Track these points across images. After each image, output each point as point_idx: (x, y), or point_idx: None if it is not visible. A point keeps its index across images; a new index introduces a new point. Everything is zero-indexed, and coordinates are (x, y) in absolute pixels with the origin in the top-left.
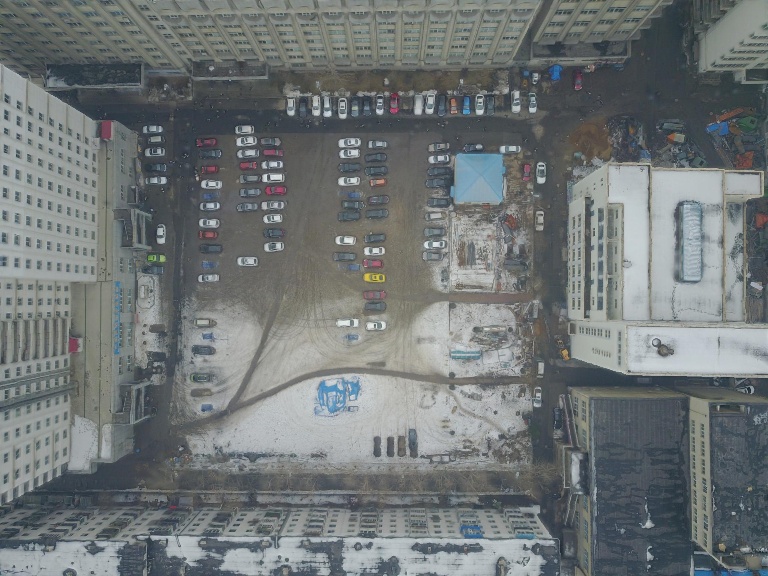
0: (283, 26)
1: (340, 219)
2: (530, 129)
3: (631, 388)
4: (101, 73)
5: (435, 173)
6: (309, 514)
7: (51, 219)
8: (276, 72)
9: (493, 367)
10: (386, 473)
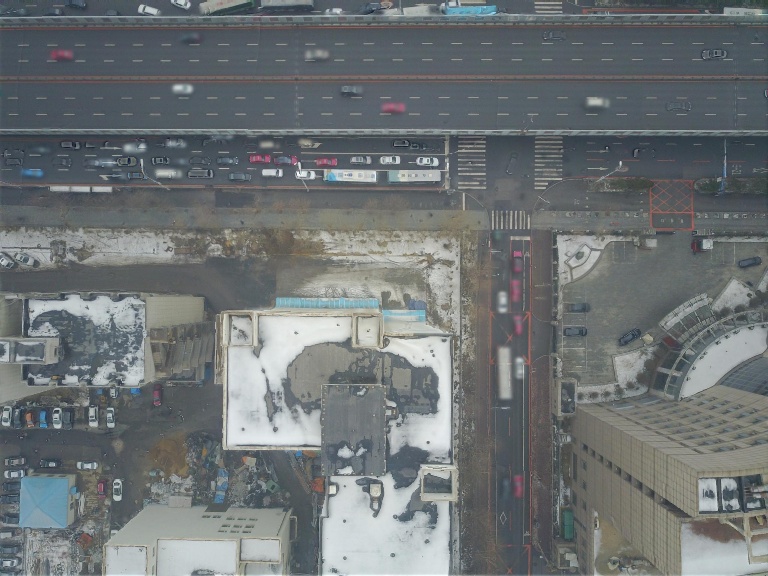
0: None
1: None
2: (110, 443)
3: None
4: None
5: (8, 489)
6: None
7: None
8: None
9: None
10: None
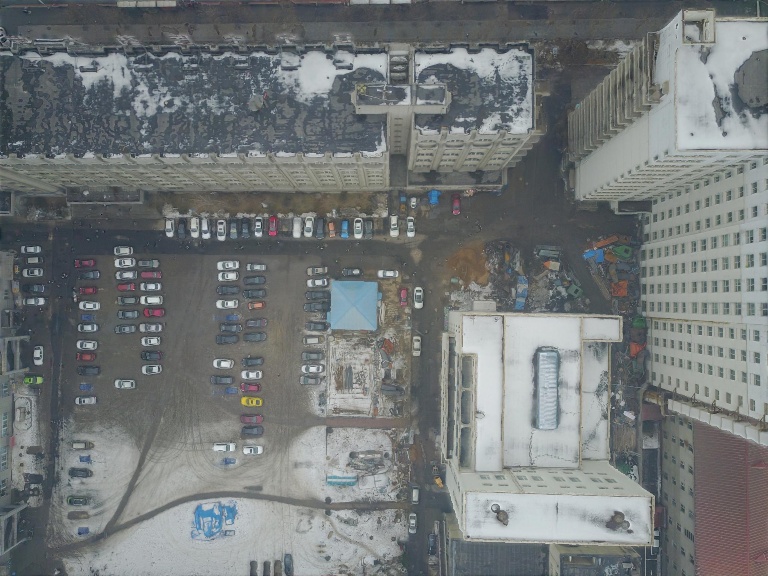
0: None
1: (218, 342)
2: (409, 253)
3: None
4: None
5: (313, 297)
6: None
7: None
8: (155, 193)
9: (369, 492)
10: None
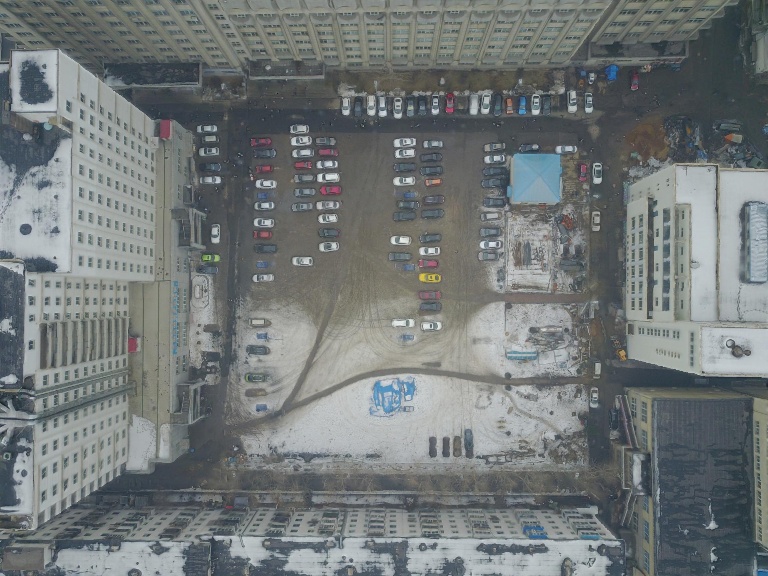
0: (348, 25)
1: (395, 219)
2: (586, 129)
3: (689, 389)
4: (159, 72)
5: (491, 173)
6: (366, 514)
7: (118, 219)
8: (331, 71)
9: (549, 367)
10: (442, 473)
